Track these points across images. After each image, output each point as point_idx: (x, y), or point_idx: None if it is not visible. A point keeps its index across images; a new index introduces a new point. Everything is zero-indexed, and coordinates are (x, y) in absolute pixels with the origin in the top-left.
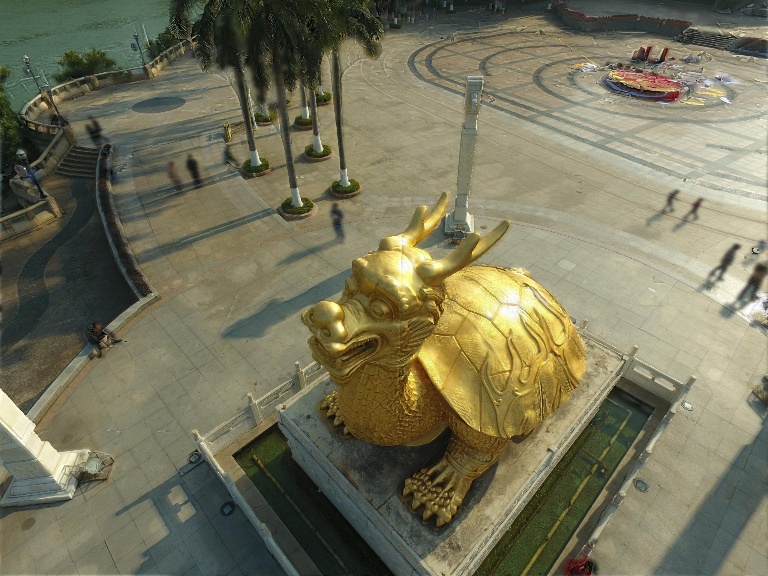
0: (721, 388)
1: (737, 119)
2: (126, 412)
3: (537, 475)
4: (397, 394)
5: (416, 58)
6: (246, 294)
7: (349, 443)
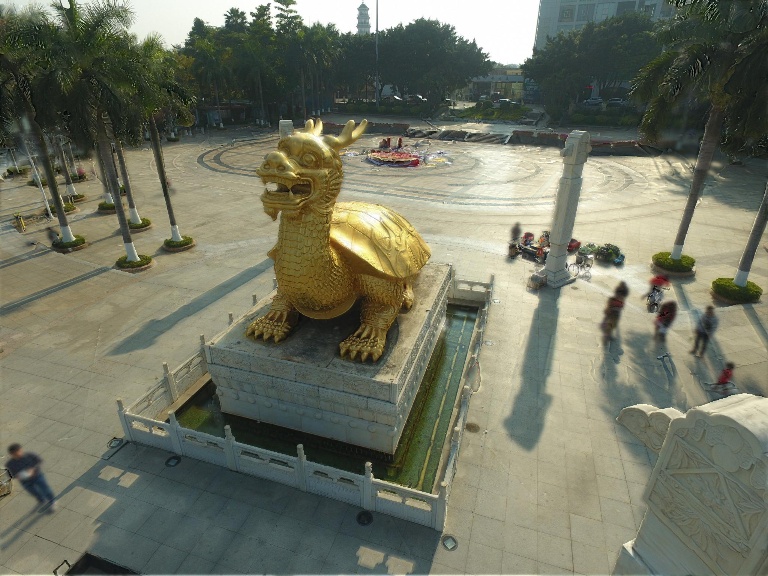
0: (510, 289)
1: (460, 171)
2: (5, 440)
3: (425, 328)
4: (326, 241)
5: (204, 159)
6: (110, 326)
7: (283, 346)
